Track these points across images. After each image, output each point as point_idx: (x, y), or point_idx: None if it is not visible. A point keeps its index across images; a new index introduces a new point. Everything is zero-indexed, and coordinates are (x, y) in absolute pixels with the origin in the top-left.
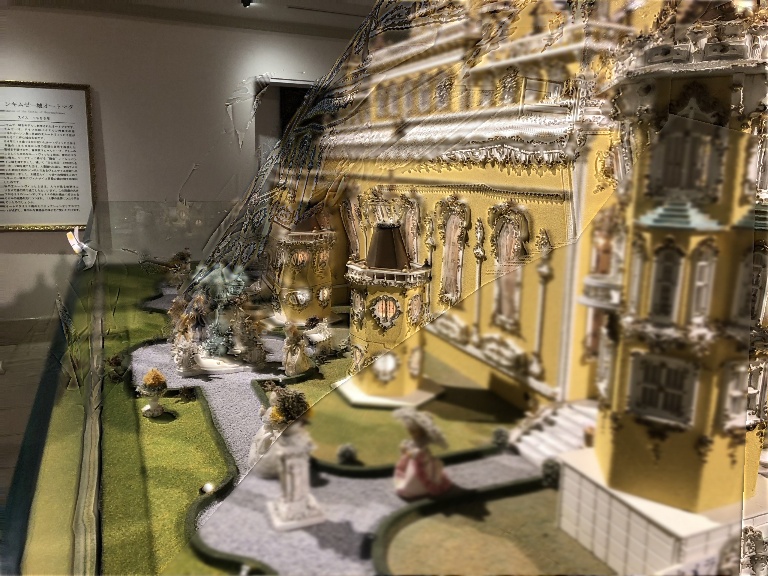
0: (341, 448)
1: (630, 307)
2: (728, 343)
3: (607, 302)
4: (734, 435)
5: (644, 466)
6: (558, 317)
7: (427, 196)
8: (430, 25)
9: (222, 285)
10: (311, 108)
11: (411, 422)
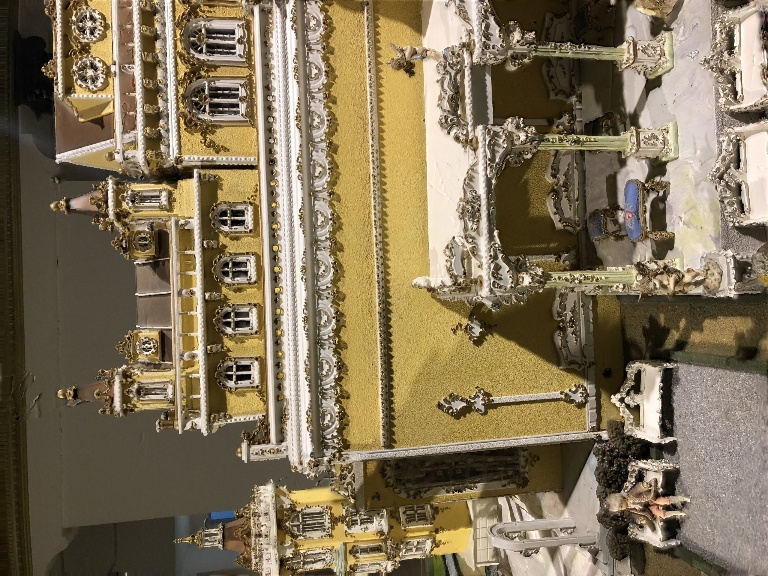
0: (326, 569)
1: None
2: None
3: None
4: None
5: None
6: None
7: None
8: None
9: None
10: None
11: None
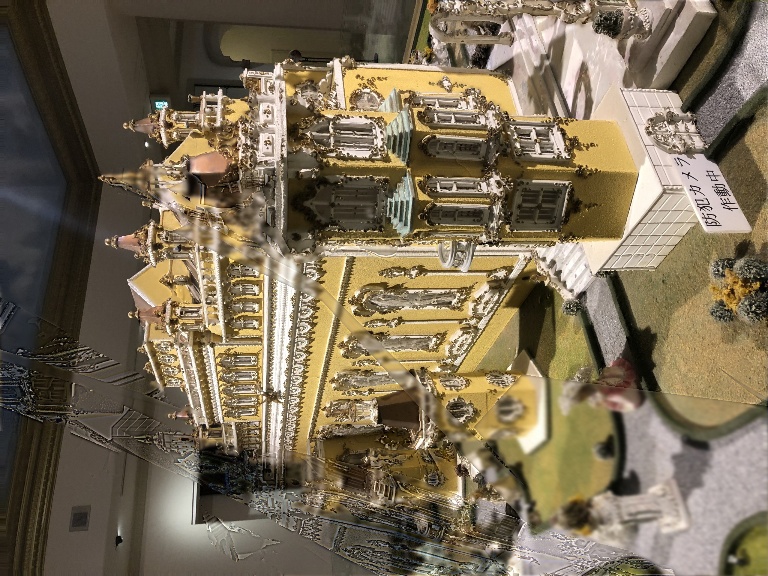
0: None
1: (630, 442)
2: (660, 401)
3: (625, 453)
4: (720, 405)
5: (739, 446)
6: (634, 478)
7: None
8: None
9: None
10: None
11: (710, 570)
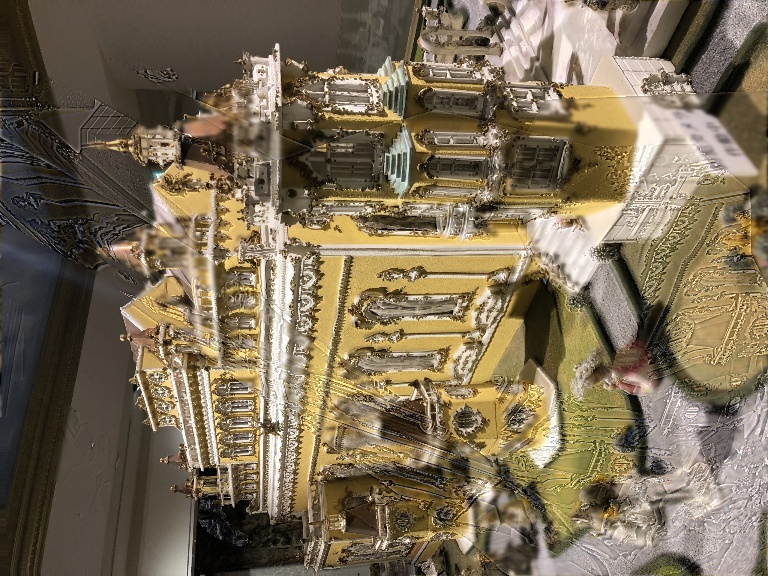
0: None
1: None
2: (704, 106)
3: None
4: None
5: None
6: None
7: (677, 304)
8: (501, 326)
9: (689, 489)
10: (498, 439)
11: None
